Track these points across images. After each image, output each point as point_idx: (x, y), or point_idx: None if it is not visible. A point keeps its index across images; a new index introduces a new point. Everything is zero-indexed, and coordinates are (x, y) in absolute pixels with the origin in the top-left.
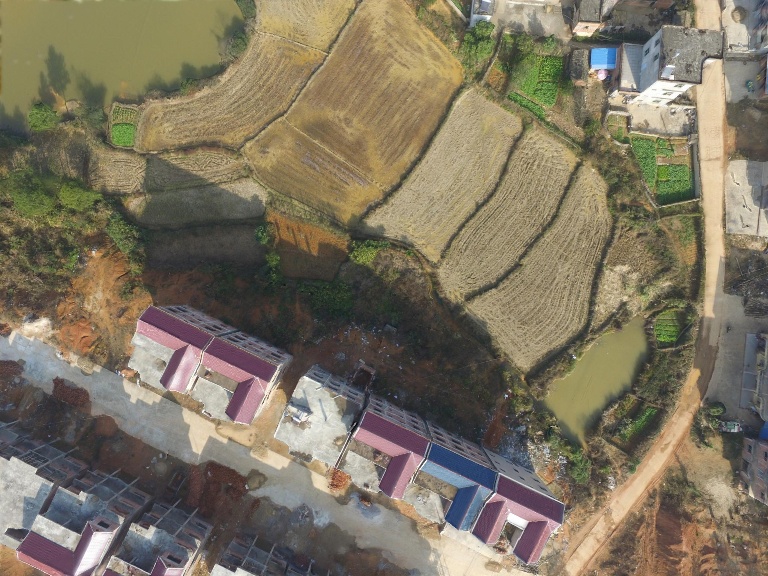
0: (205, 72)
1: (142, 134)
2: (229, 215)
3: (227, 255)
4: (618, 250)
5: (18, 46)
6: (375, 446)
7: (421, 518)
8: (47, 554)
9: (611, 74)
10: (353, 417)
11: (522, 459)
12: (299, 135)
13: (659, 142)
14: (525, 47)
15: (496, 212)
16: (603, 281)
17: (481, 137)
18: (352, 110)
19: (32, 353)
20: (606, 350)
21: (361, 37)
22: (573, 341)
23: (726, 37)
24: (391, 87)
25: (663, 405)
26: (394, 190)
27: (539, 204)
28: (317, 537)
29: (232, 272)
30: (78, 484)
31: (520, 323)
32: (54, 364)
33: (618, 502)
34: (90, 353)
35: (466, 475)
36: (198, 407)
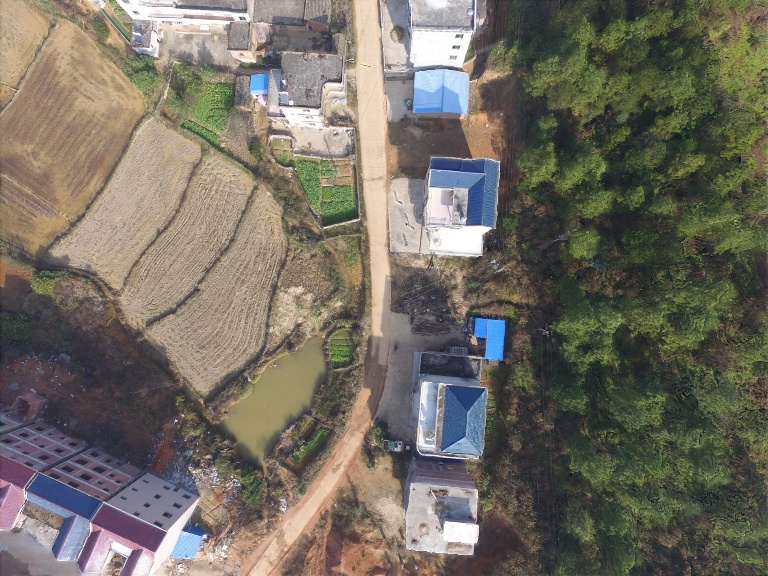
0: None
1: None
2: None
3: None
4: (291, 272)
5: None
6: None
7: None
8: None
9: None
10: None
11: (187, 484)
12: None
13: (322, 164)
14: (185, 76)
15: (175, 238)
16: (278, 303)
17: (162, 165)
18: (39, 144)
19: None
20: (285, 371)
21: (48, 72)
22: (249, 364)
23: (383, 57)
24: (77, 120)
25: (333, 426)
26: (78, 220)
27: (217, 229)
28: None
29: None
30: None
31: (198, 347)
32: None
33: (290, 524)
34: None
35: (64, 505)
36: None
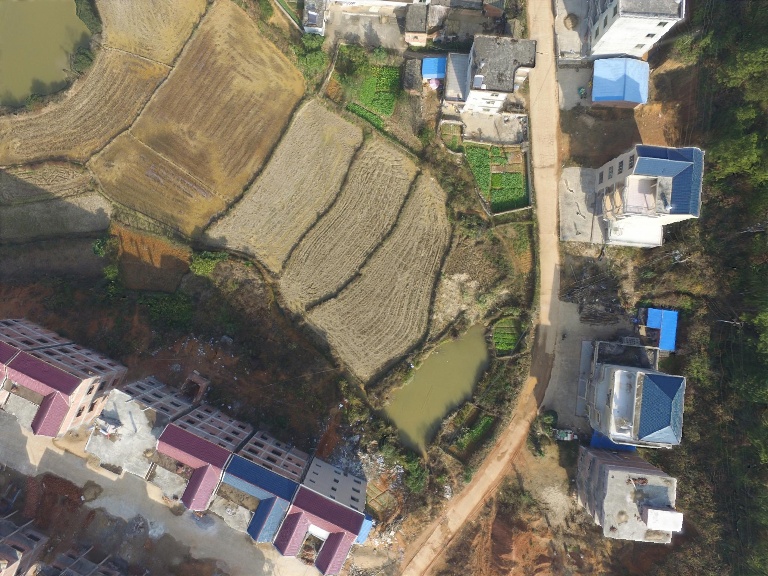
0: (54, 87)
1: None
2: (75, 228)
3: (71, 268)
4: (456, 258)
5: None
6: (177, 458)
7: None
8: None
9: (443, 83)
10: None
11: (354, 469)
12: (143, 148)
13: (493, 150)
14: (356, 58)
15: (336, 222)
16: (441, 290)
17: (322, 148)
18: (196, 123)
19: None
20: (446, 359)
21: (205, 50)
22: (412, 350)
23: (558, 44)
24: (234, 99)
25: (499, 413)
26: (236, 201)
27: (379, 213)
28: (152, 548)
29: (71, 285)
30: None
31: (359, 332)
32: None
33: (454, 511)
34: None
35: (264, 487)
36: None
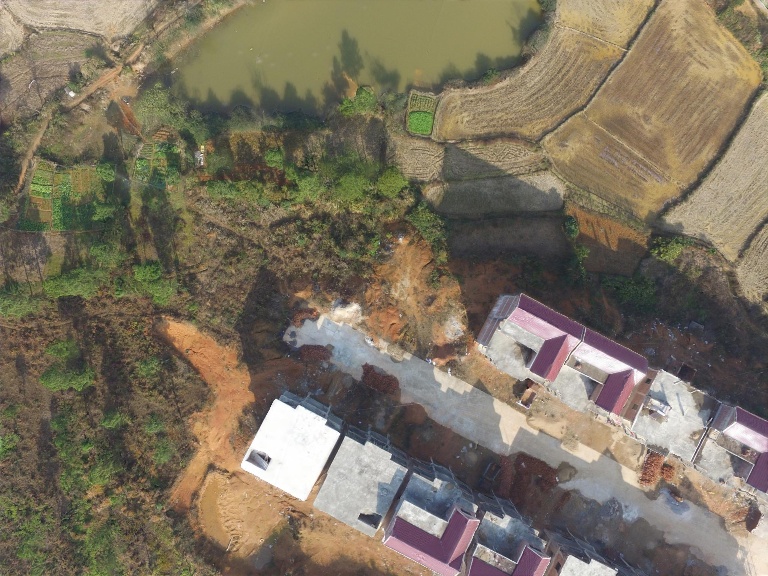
0: (500, 63)
1: (439, 123)
2: (527, 207)
3: (527, 247)
4: None
5: (311, 30)
6: (745, 441)
7: (729, 515)
8: (418, 540)
9: None
10: (710, 412)
11: None
12: (598, 130)
13: None
14: None
15: None
16: None
17: None
18: (651, 107)
19: (341, 338)
20: None
21: (661, 35)
22: None
23: None
24: (690, 86)
25: None
26: (693, 188)
27: None
28: (626, 531)
29: (541, 264)
30: (421, 471)
31: None
32: (363, 350)
33: None
34: (400, 340)
35: None
36: (509, 398)
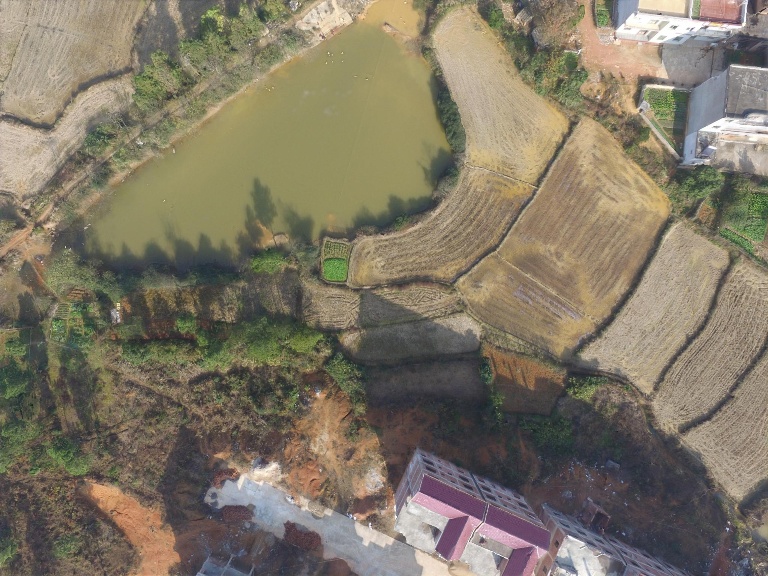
0: (413, 204)
1: (354, 269)
2: (444, 350)
3: (445, 391)
4: None
5: (223, 179)
6: None
7: None
8: None
9: None
10: (616, 574)
11: None
12: (511, 269)
13: None
14: (743, 189)
15: (707, 344)
16: None
17: (690, 270)
18: (563, 244)
19: (262, 498)
20: None
21: (570, 171)
22: None
23: None
24: (600, 221)
25: None
26: (607, 323)
27: (748, 336)
28: None
29: (458, 412)
30: None
31: (733, 453)
32: (284, 508)
33: None
34: (320, 496)
35: None
36: None
